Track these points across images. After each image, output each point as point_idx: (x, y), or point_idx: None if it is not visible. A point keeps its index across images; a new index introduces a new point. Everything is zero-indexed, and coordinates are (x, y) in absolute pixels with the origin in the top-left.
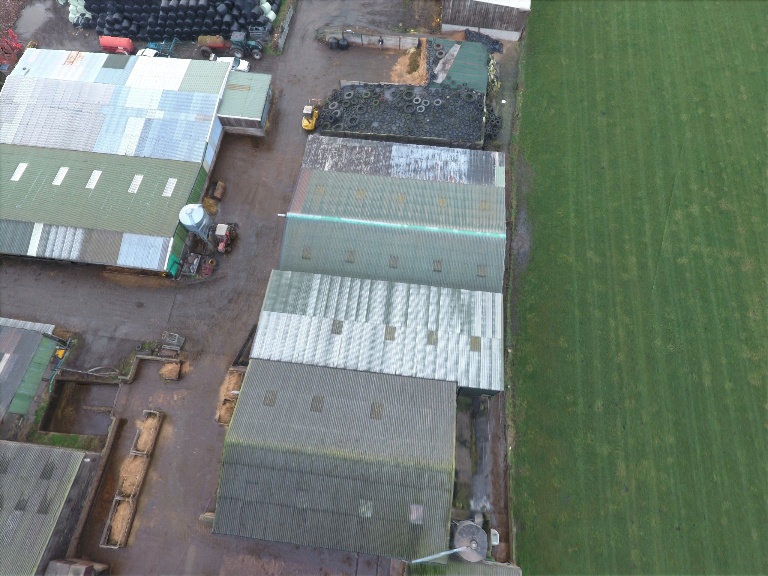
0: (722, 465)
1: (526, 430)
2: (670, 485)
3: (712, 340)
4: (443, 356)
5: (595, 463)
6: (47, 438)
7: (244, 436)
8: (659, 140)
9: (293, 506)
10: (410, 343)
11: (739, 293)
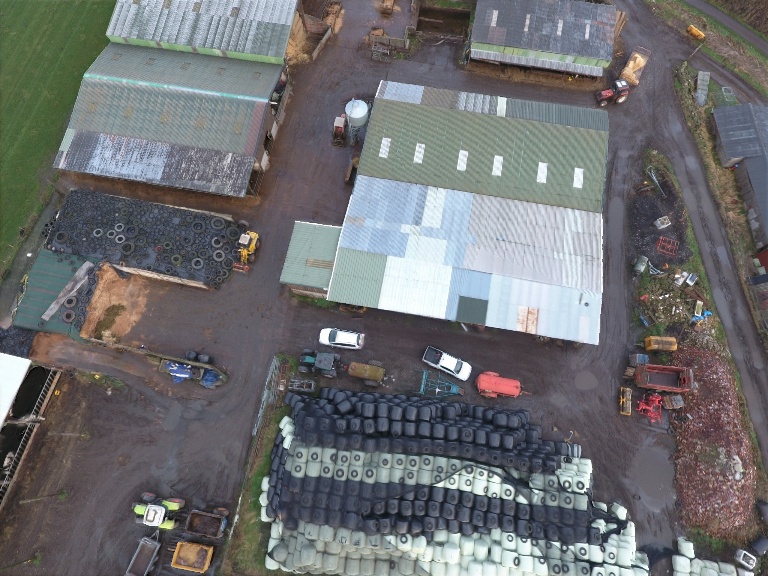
0: None
1: None
2: None
3: None
4: None
5: None
6: (463, 6)
7: None
8: None
9: None
10: (184, 0)
11: None
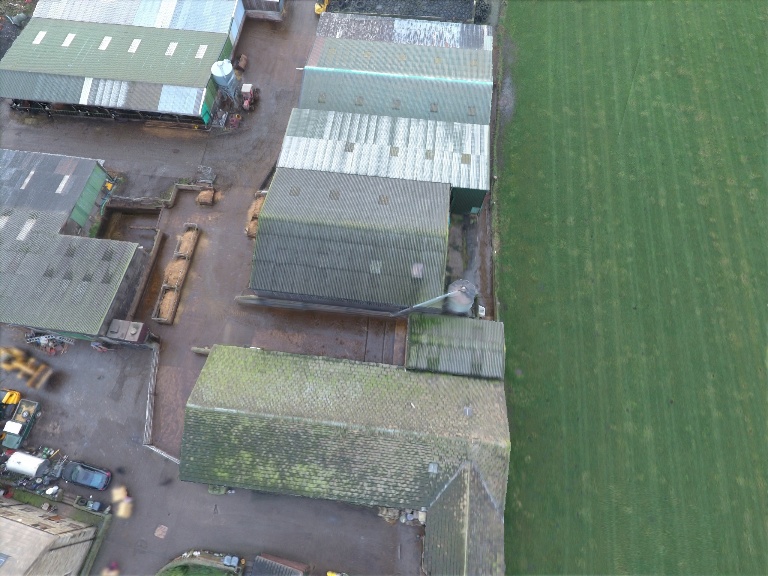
0: (673, 263)
1: (509, 239)
2: (629, 277)
3: (668, 172)
4: (439, 167)
5: (567, 262)
6: None
7: (275, 213)
8: (627, 21)
9: (316, 266)
10: (411, 158)
11: (692, 137)
